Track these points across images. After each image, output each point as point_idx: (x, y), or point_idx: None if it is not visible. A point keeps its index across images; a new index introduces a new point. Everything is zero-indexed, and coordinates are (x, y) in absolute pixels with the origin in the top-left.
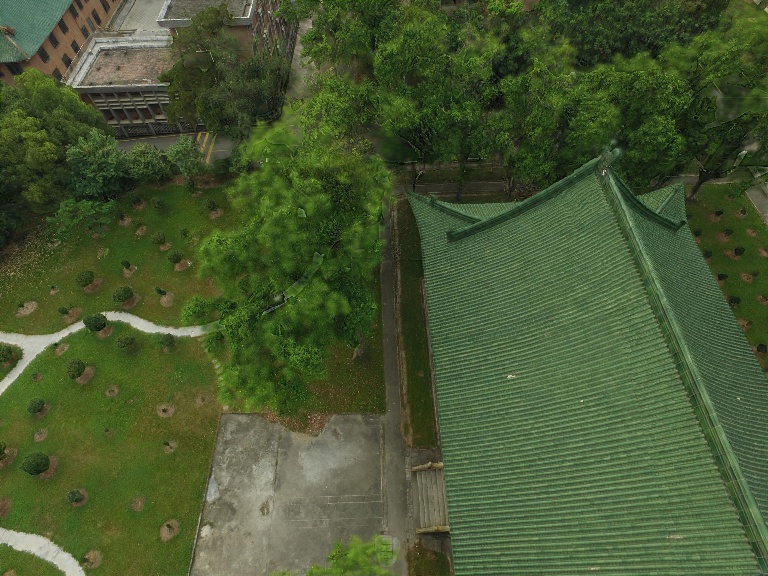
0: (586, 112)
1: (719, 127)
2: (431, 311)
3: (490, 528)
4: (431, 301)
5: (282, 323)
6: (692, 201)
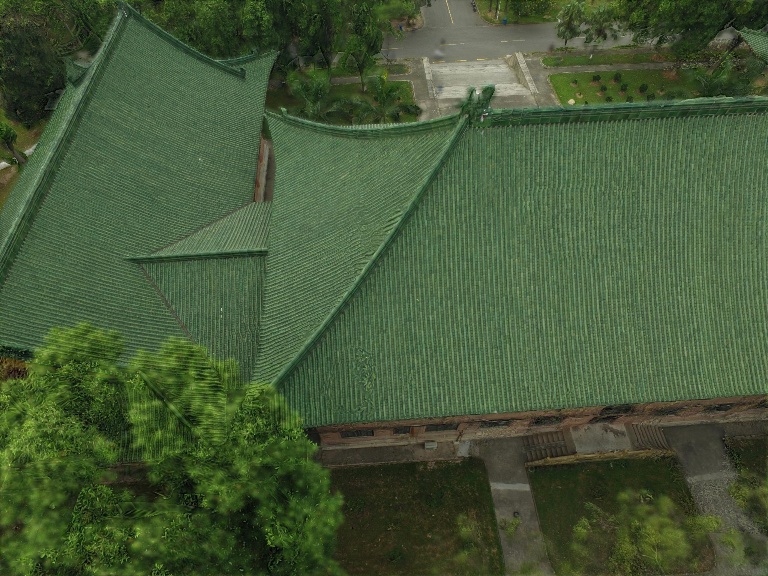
0: (205, 1)
1: (354, 25)
2: (45, 131)
3: (3, 233)
4: (48, 126)
5: (2, 179)
6: (365, 92)
